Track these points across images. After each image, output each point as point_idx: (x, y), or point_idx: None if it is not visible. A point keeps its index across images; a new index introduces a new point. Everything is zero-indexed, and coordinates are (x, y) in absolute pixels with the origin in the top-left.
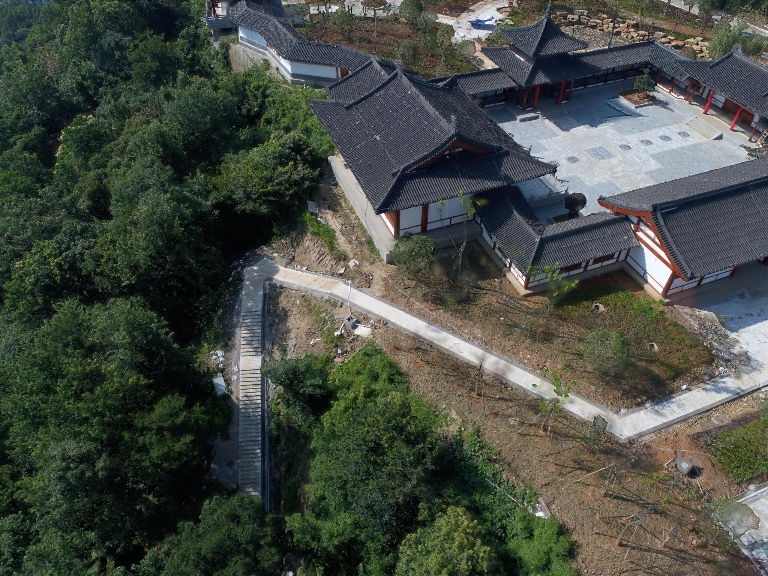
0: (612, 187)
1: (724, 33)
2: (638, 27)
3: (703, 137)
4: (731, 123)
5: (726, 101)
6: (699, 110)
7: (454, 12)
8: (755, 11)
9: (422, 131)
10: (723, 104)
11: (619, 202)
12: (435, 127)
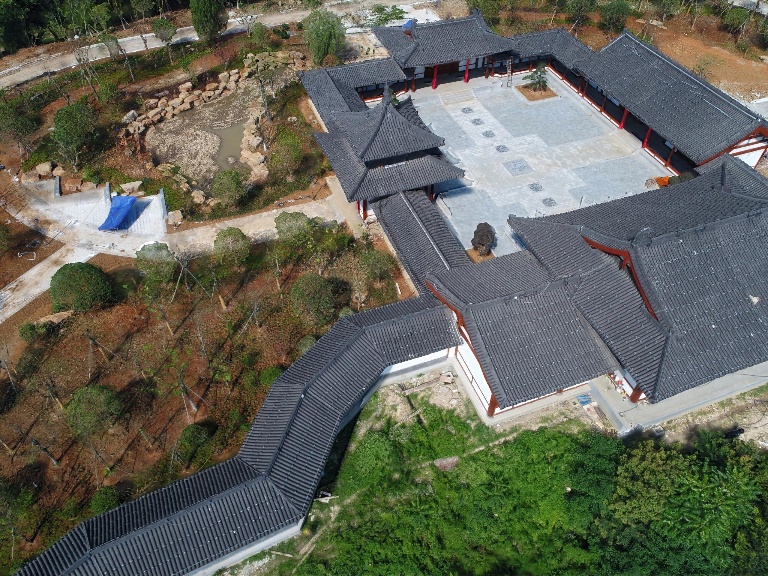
0: (584, 170)
1: (328, 27)
2: (195, 86)
3: (471, 101)
4: (456, 79)
5: (427, 69)
6: (427, 90)
7: (35, 247)
8: (166, 15)
9: (762, 241)
10: (425, 73)
11: (718, 147)
12: (763, 224)
